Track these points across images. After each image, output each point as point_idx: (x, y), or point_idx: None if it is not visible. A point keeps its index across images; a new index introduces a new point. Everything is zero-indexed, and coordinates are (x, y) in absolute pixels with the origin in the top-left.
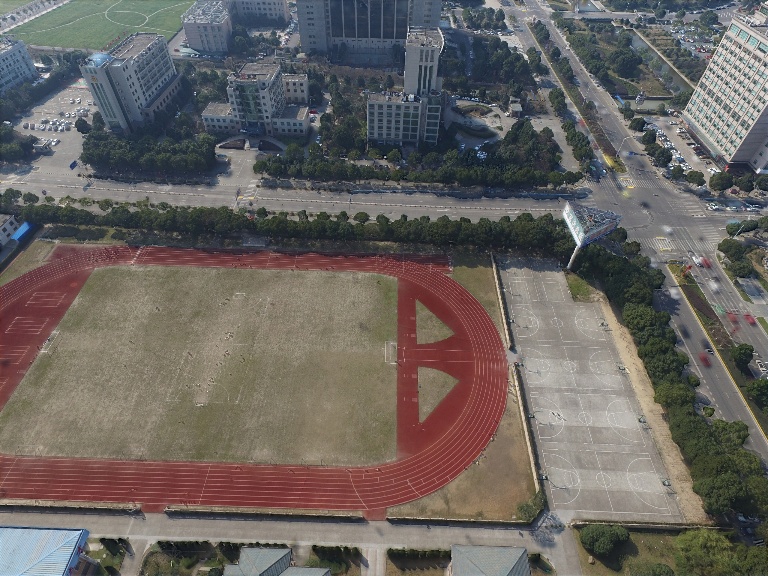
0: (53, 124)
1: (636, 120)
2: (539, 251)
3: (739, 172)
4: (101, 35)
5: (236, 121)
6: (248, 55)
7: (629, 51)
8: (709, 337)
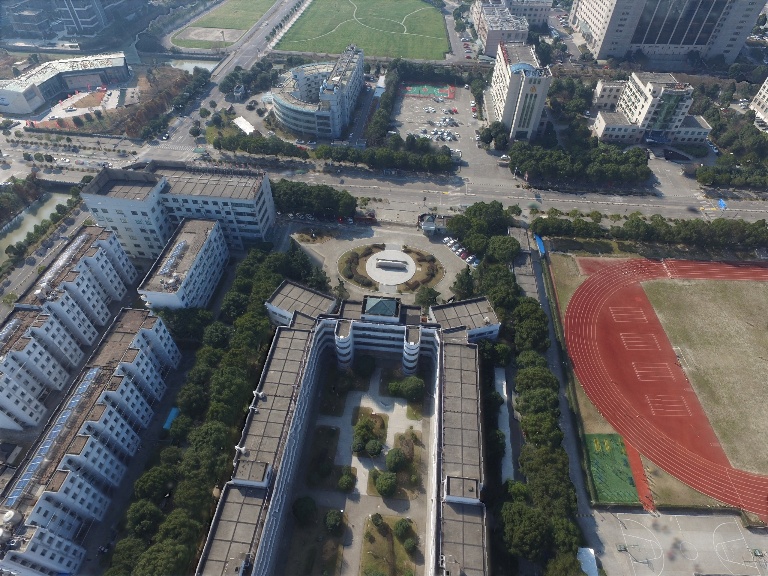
0: (435, 134)
1: None
2: None
3: None
4: (377, 42)
5: (640, 130)
6: (547, 62)
7: None
8: None
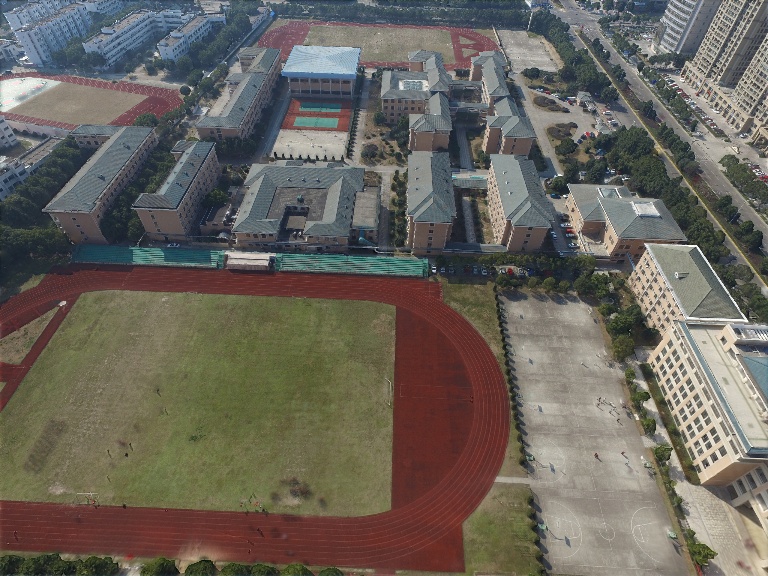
0: None
1: None
2: (515, 26)
3: None
4: None
5: None
6: None
7: None
8: (586, 45)
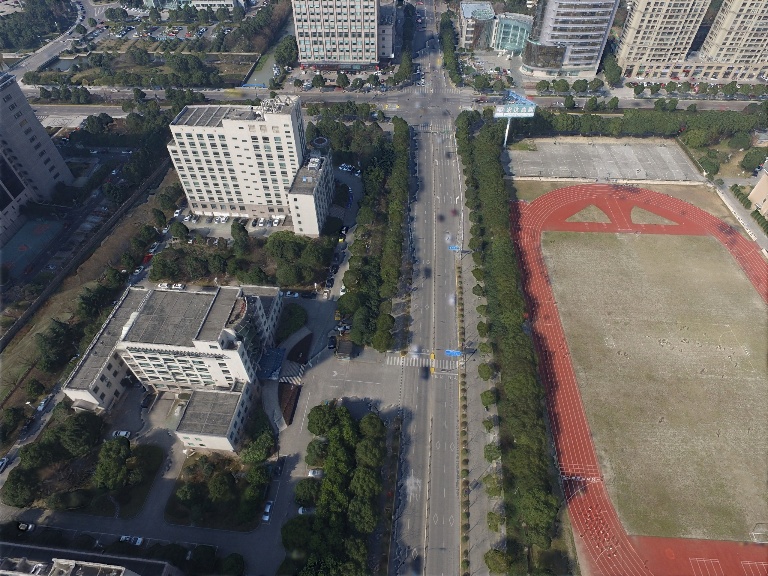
0: None
1: (318, 78)
2: None
3: (381, 65)
4: None
5: (253, 382)
6: None
7: (176, 57)
8: None
